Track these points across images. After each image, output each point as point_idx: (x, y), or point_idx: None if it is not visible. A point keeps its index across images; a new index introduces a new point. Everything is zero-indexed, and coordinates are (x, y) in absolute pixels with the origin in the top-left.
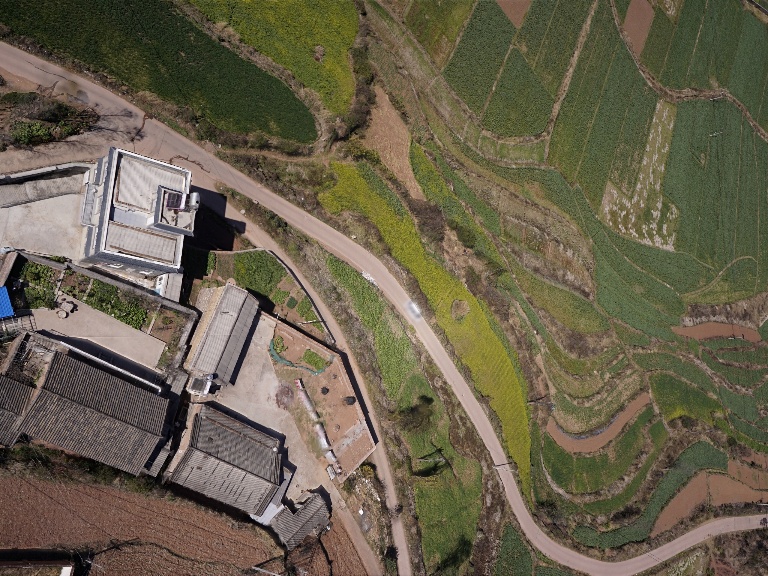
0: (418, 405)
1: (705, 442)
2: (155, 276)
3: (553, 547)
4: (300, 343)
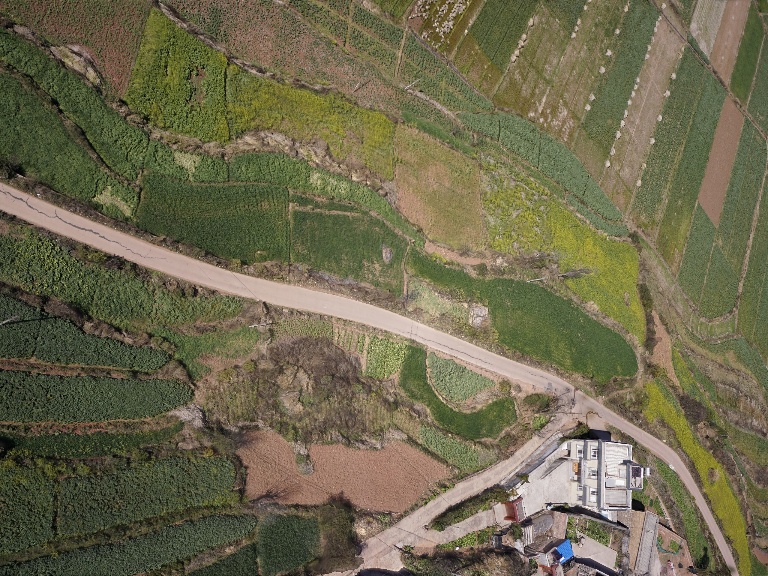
0: (704, 556)
1: None
2: None
3: None
4: (668, 536)
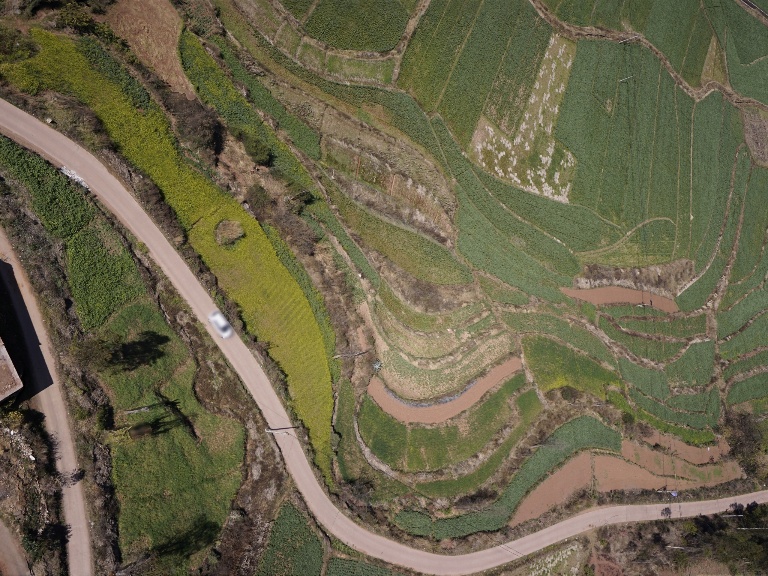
0: (136, 342)
1: (591, 417)
2: None
3: (360, 535)
4: None
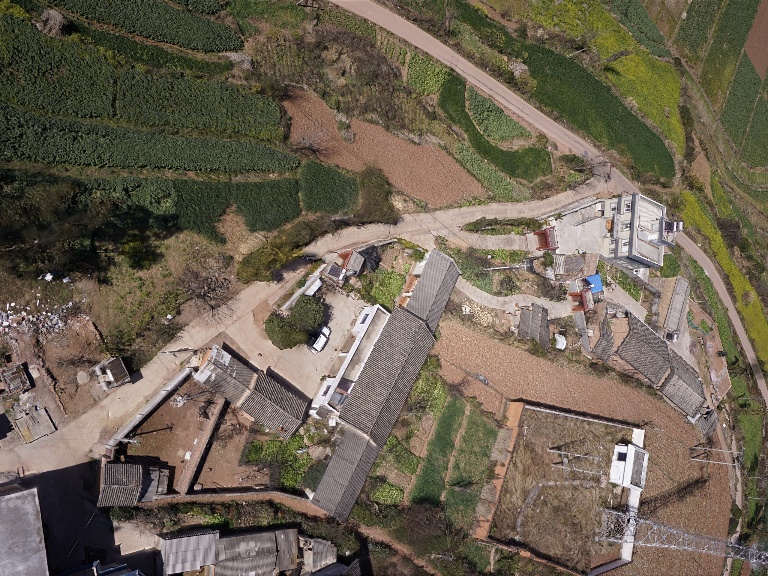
0: (735, 362)
1: None
2: (632, 269)
3: None
4: (699, 315)
